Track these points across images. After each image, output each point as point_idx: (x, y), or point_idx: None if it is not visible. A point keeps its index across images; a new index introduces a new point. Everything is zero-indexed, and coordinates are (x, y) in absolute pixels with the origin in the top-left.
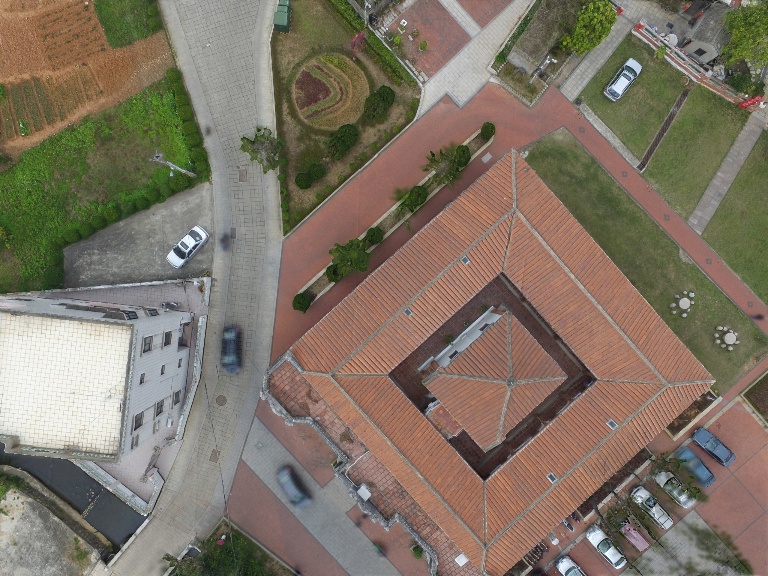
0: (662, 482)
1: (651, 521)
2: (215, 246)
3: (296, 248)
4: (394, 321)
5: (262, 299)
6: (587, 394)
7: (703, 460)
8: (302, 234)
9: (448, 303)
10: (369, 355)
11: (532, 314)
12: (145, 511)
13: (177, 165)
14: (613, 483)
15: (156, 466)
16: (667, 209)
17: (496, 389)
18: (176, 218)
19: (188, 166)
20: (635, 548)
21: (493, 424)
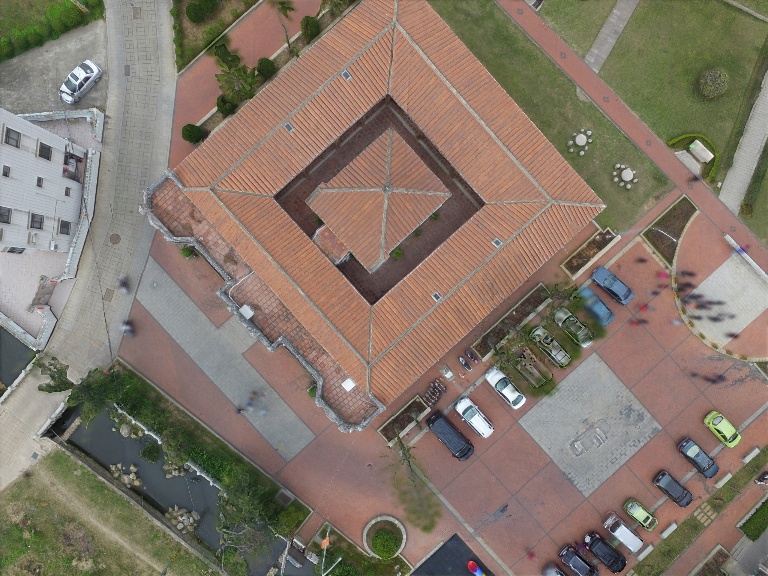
0: (560, 320)
1: (551, 363)
2: (109, 83)
3: (190, 86)
4: (274, 136)
5: (156, 137)
6: (475, 218)
7: (604, 301)
8: (196, 72)
9: (332, 122)
10: (250, 171)
11: (428, 152)
12: (34, 345)
13: (70, 1)
14: (512, 323)
15: (48, 304)
16: (563, 47)
17: (374, 198)
18: (70, 55)
19: (80, 1)
20: (533, 386)
21: (375, 240)
